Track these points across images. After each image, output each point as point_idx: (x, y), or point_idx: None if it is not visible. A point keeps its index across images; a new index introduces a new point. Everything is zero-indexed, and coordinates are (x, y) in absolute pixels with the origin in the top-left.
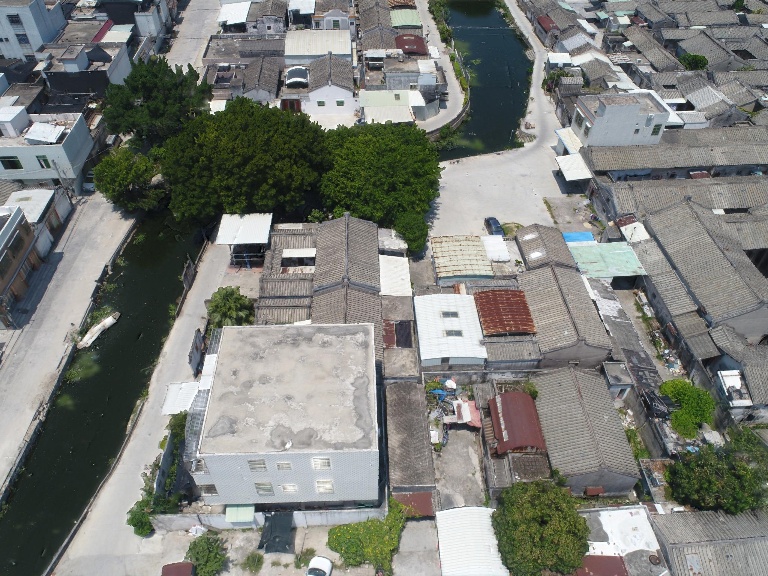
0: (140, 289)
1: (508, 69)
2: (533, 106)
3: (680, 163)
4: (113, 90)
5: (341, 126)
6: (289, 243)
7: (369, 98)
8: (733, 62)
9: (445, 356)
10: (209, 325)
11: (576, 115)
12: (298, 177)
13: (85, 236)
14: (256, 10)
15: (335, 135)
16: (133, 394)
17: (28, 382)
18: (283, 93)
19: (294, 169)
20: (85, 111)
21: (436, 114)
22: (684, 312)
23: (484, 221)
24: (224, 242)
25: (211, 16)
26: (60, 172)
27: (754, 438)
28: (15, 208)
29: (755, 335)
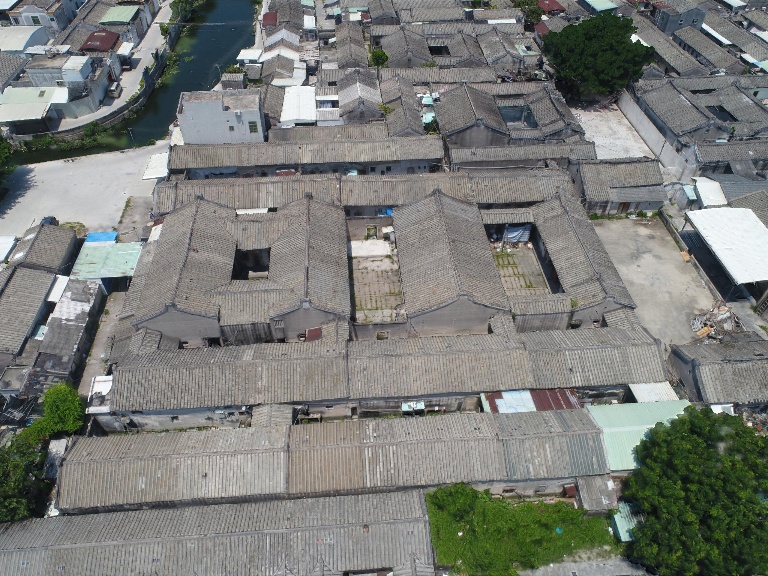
0: None
1: None
2: None
3: (262, 161)
4: None
5: None
6: None
7: (12, 95)
8: (413, 58)
9: None
10: None
11: None
12: None
13: None
14: None
15: None
16: None
17: None
18: None
19: None
20: None
21: (93, 111)
22: (128, 315)
23: (33, 221)
24: None
25: None
26: None
27: (27, 447)
28: None
29: (193, 339)
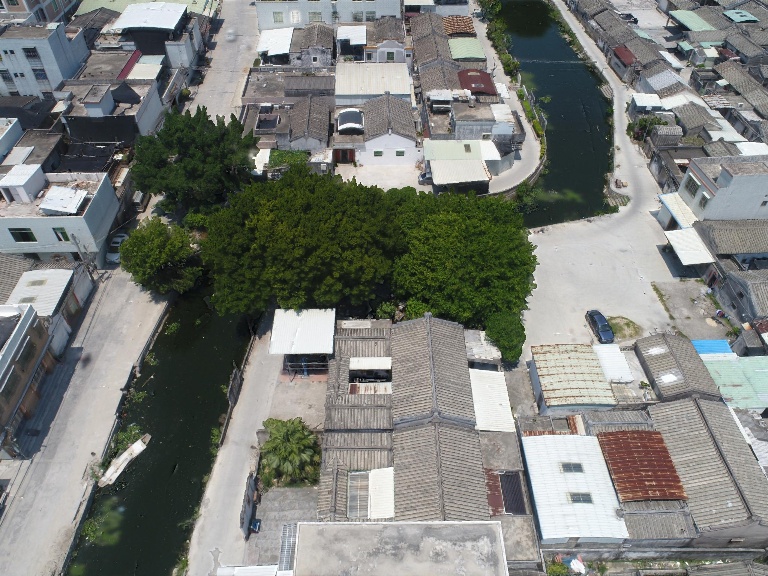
0: (174, 400)
1: (583, 108)
2: (621, 158)
3: None
4: (143, 143)
5: (416, 198)
6: (357, 350)
7: (435, 149)
8: None
9: (575, 535)
10: (261, 460)
11: (687, 180)
12: (370, 269)
13: (108, 325)
14: (300, 38)
15: (410, 211)
16: (168, 559)
17: (37, 541)
18: (335, 142)
19: (366, 260)
20: (110, 164)
21: (510, 167)
22: None
23: (588, 317)
24: (279, 351)
25: (247, 40)
26: (80, 246)
27: None
28: (26, 307)
29: None
